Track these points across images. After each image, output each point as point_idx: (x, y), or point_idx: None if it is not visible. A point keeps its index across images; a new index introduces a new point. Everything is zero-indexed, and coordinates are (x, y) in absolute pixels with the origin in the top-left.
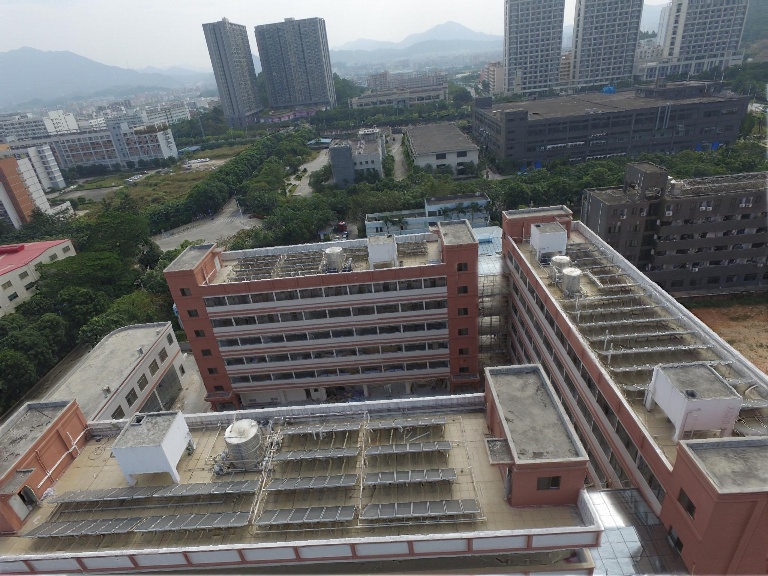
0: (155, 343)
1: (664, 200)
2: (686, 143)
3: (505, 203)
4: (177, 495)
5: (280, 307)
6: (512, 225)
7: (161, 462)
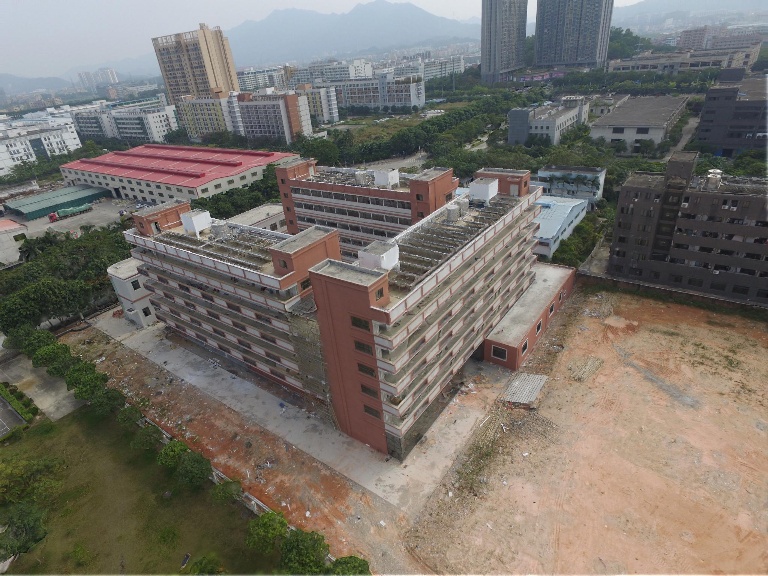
0: (279, 214)
1: (683, 191)
2: None
3: None
4: (190, 237)
5: (324, 202)
6: None
7: (193, 226)
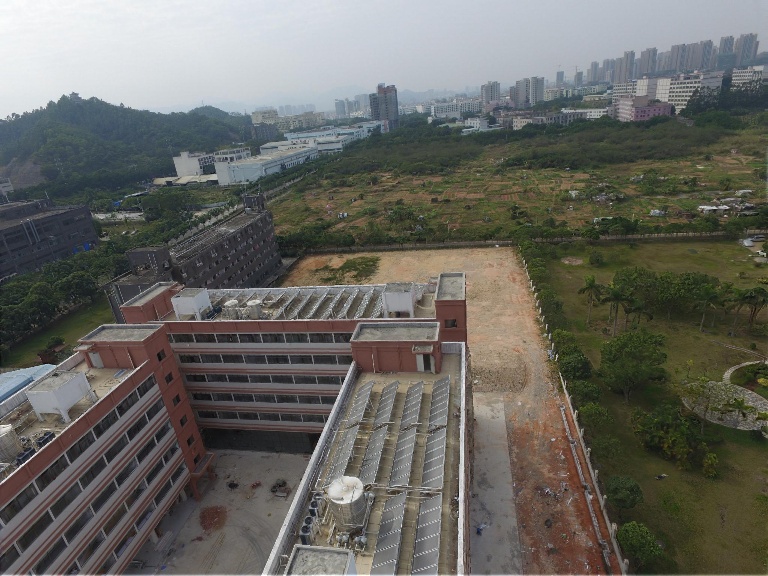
0: None
1: (176, 267)
2: (64, 250)
3: None
4: None
5: None
6: (146, 310)
7: None
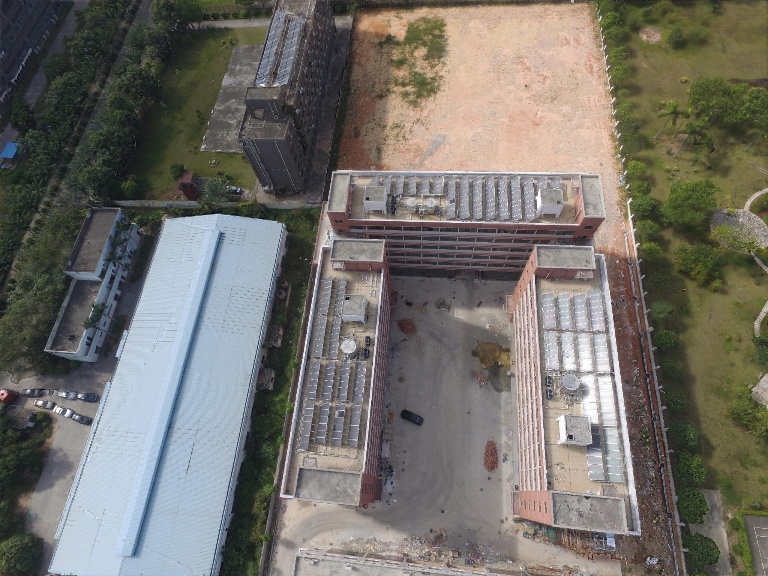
0: None
1: (290, 106)
2: None
3: (102, 196)
4: None
5: None
6: (346, 212)
7: None
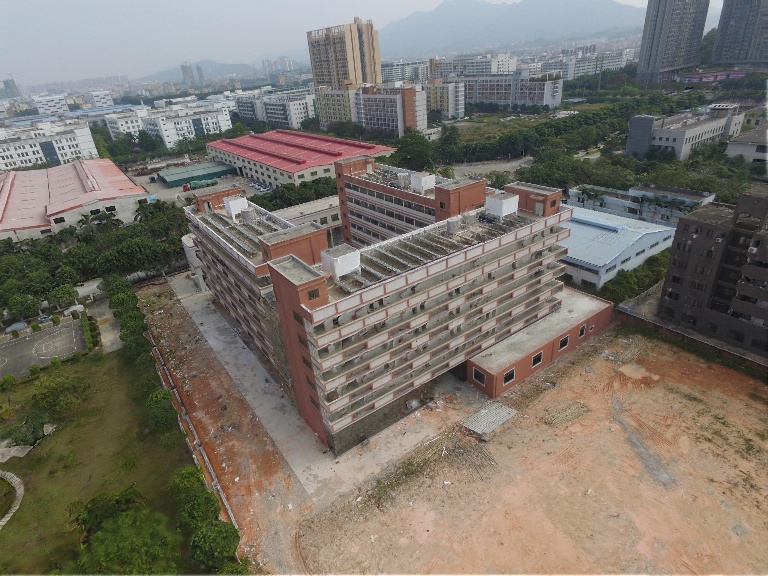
0: None
1: (754, 232)
2: None
3: None
4: (224, 218)
5: (369, 199)
6: None
7: None
